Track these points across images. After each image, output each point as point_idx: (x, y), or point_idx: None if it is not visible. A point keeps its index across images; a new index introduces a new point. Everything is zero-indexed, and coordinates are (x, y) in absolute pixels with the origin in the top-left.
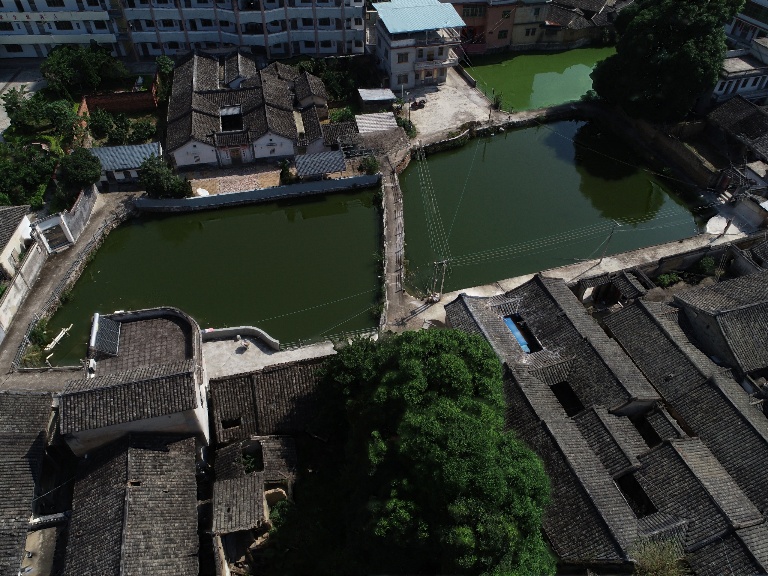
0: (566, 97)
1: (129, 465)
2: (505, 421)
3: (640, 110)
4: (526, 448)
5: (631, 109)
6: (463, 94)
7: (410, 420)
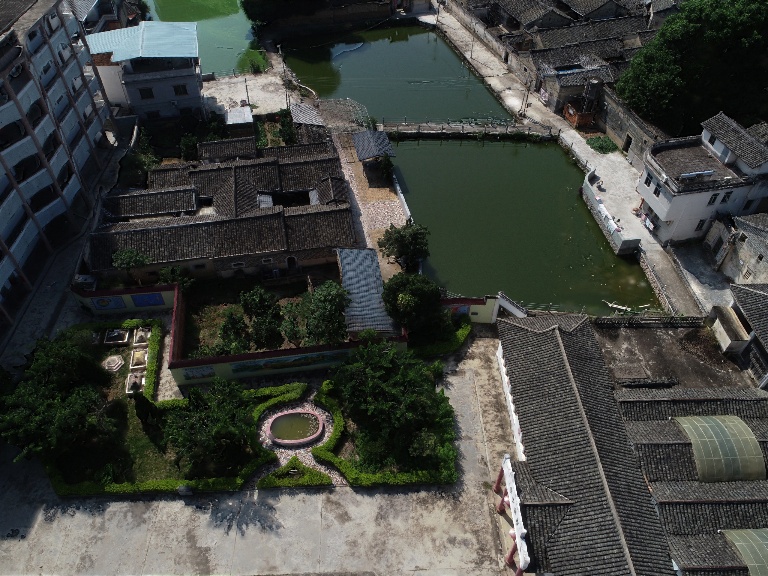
0: (241, 46)
1: None
2: None
3: (316, 5)
4: None
5: (312, 8)
6: (226, 85)
7: None
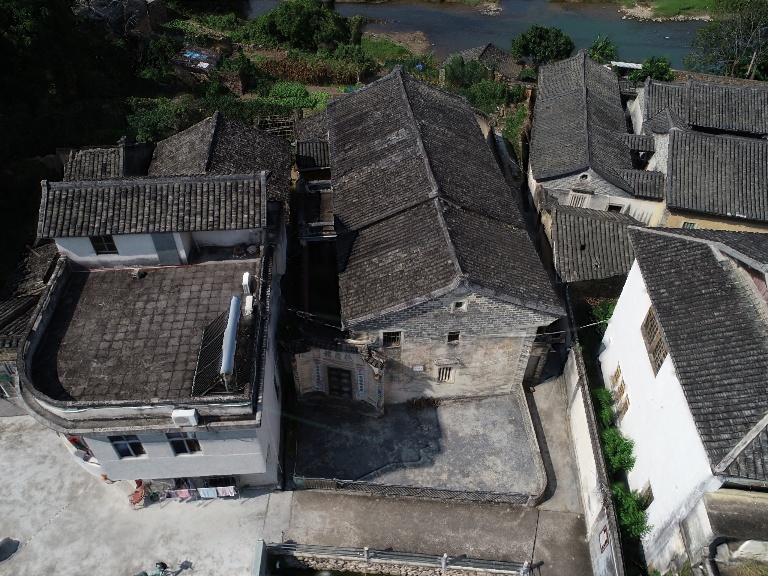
0: None
1: None
2: None
3: None
4: None
5: None
6: None
7: None
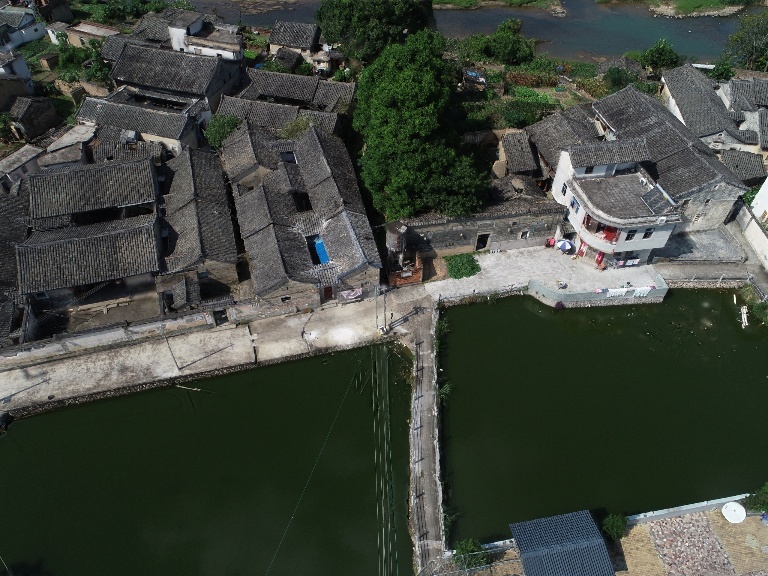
0: None
1: None
2: (354, 189)
3: None
4: (346, 172)
5: None
6: None
7: None
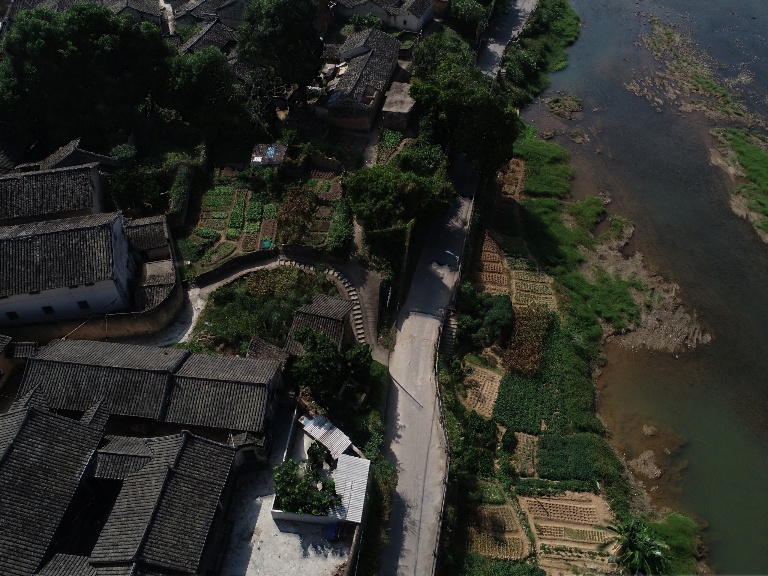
0: None
1: (6, 178)
2: None
3: None
4: None
5: None
6: None
7: (63, 27)
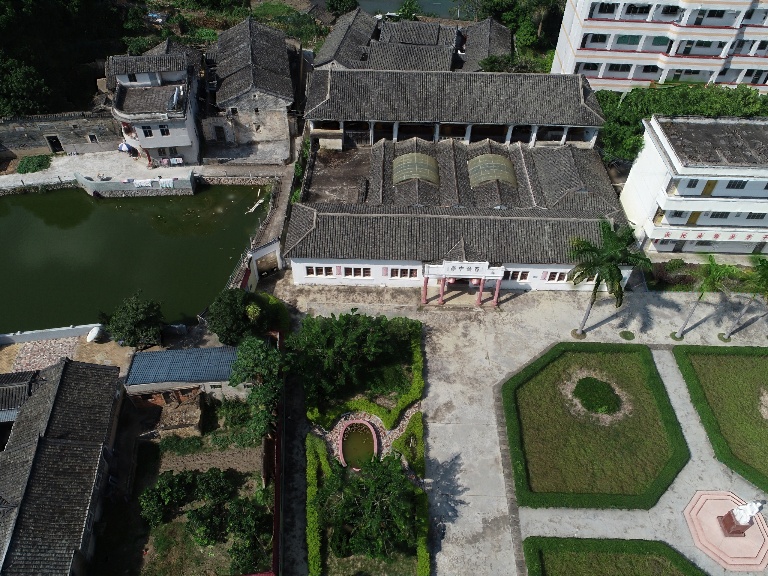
0: None
1: None
2: None
3: None
4: None
5: None
6: None
7: None
